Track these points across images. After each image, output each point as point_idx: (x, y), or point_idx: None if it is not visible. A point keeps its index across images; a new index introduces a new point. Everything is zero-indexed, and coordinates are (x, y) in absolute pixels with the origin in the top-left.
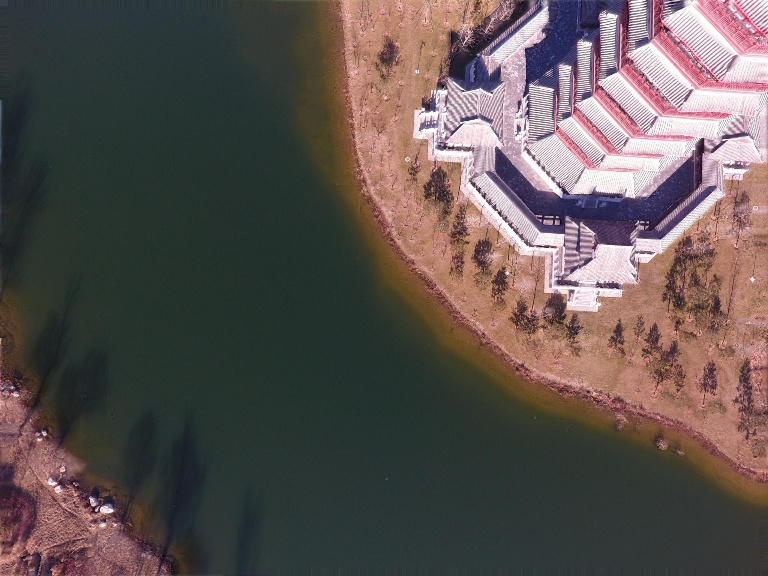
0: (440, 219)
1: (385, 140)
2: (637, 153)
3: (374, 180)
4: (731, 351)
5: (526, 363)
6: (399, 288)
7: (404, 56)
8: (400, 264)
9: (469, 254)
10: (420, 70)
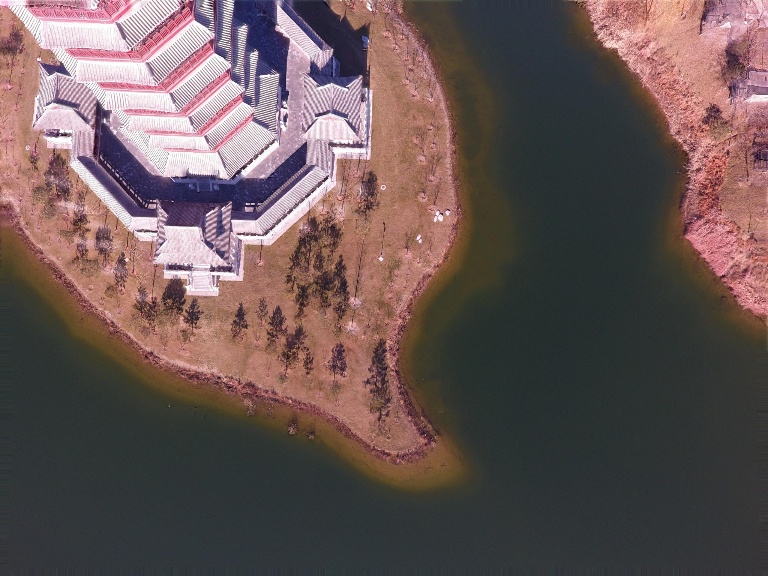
0: (46, 206)
1: (8, 129)
2: (169, 131)
3: (2, 170)
4: (336, 331)
5: (155, 351)
6: (30, 279)
7: (27, 44)
8: (29, 254)
9: (91, 242)
10: (42, 57)
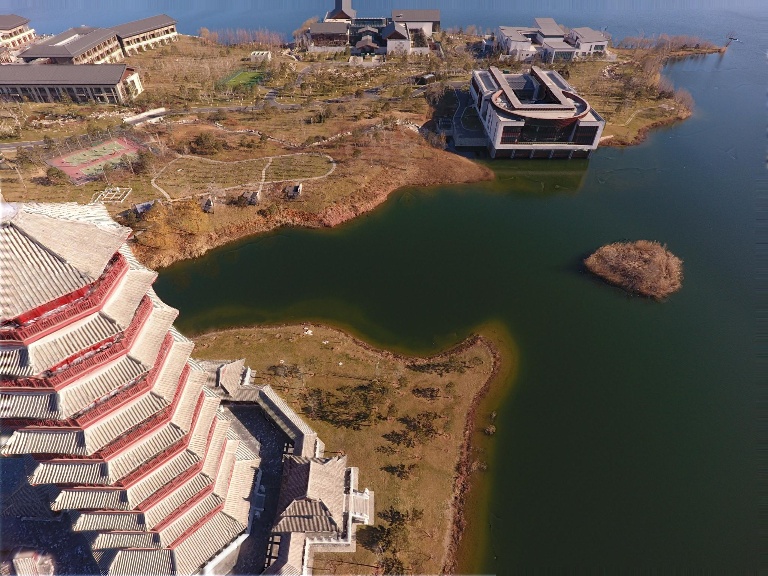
0: None
1: None
2: None
3: None
4: (402, 379)
5: (437, 572)
6: None
7: None
8: None
9: None
10: None
